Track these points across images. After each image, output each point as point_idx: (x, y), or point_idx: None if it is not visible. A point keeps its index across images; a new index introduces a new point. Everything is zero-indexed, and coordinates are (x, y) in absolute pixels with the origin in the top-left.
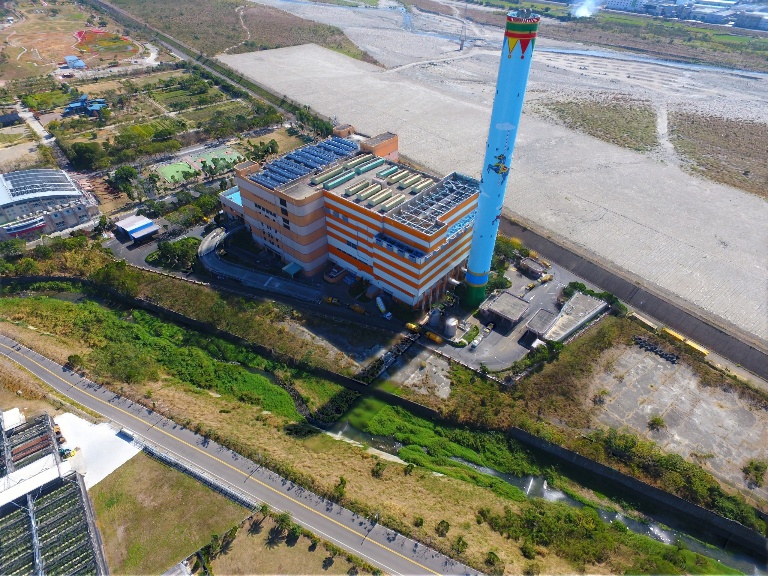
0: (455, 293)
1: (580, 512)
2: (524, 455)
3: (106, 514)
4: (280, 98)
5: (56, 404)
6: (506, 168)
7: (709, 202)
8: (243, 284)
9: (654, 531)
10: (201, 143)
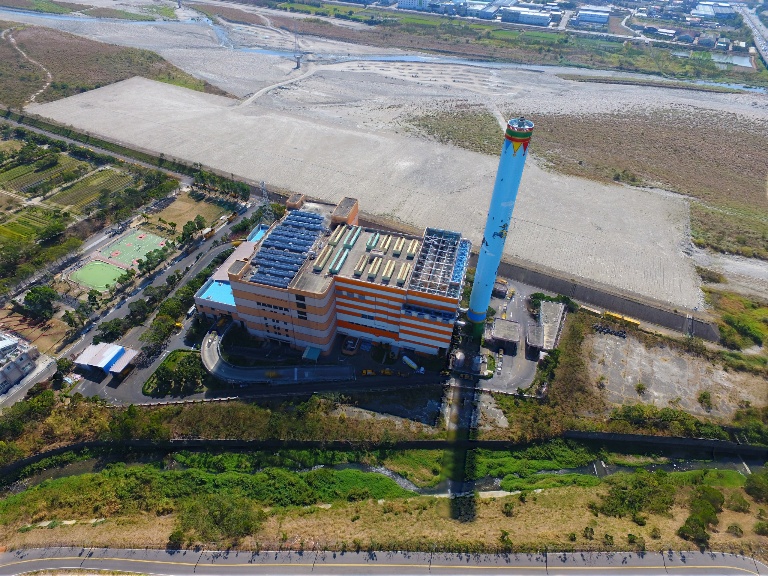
0: (465, 333)
1: None
2: (581, 448)
3: None
4: (155, 156)
5: None
6: None
7: (573, 194)
8: (272, 385)
9: (677, 466)
10: (99, 231)
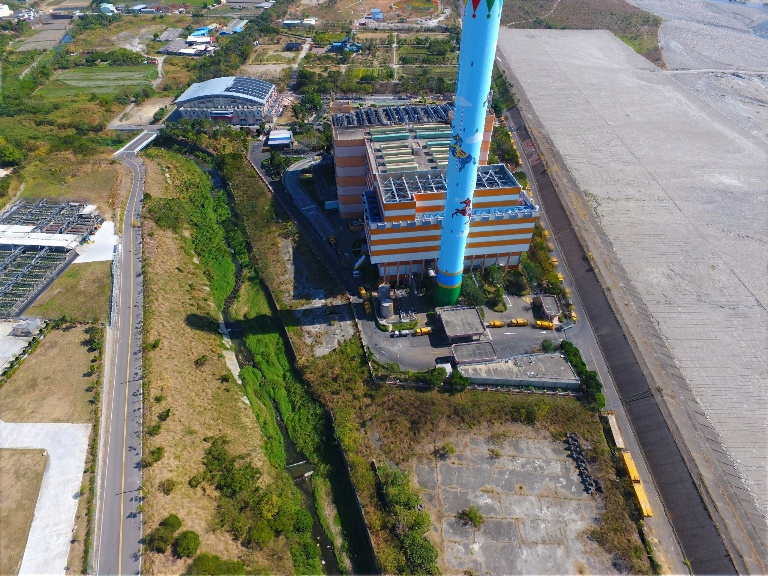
0: (421, 282)
1: (283, 503)
2: (318, 438)
3: (63, 279)
4: (501, 72)
5: None
6: (464, 153)
7: None
8: (293, 202)
9: None
10: (394, 94)
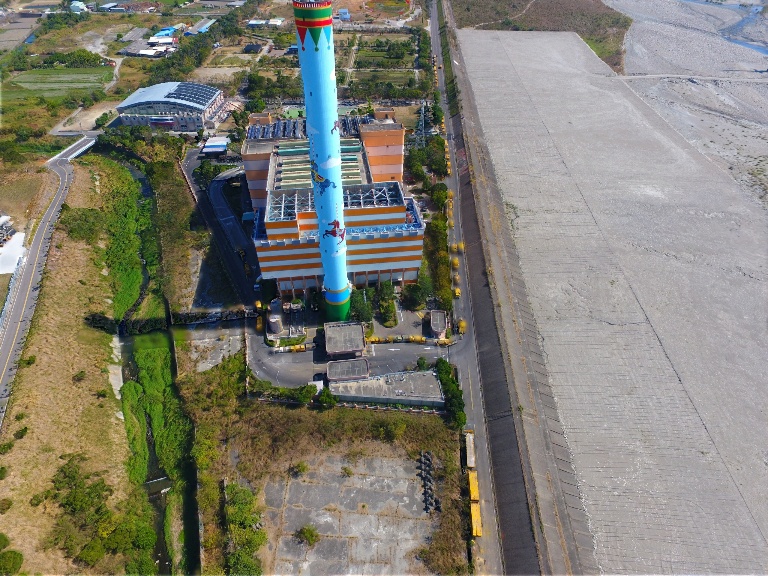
0: None
1: (123, 521)
2: (180, 455)
3: None
4: (453, 77)
5: (28, 226)
6: (322, 178)
7: None
8: (214, 212)
9: None
10: (342, 99)
